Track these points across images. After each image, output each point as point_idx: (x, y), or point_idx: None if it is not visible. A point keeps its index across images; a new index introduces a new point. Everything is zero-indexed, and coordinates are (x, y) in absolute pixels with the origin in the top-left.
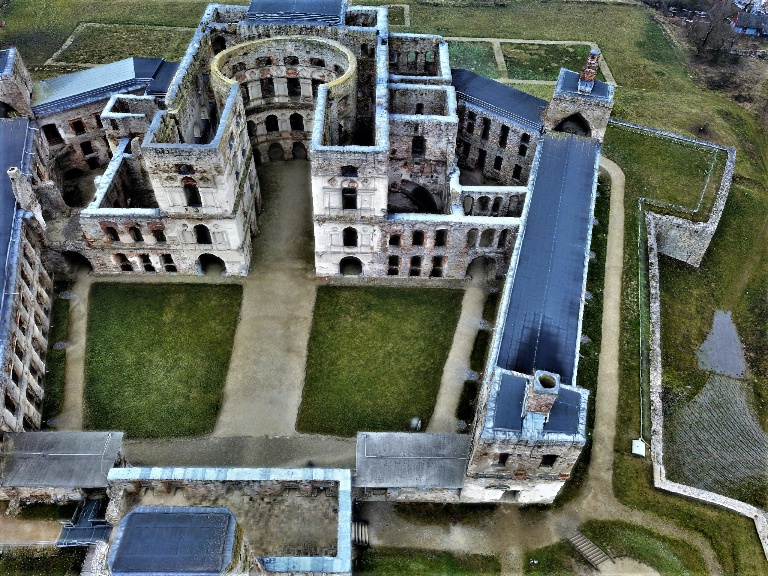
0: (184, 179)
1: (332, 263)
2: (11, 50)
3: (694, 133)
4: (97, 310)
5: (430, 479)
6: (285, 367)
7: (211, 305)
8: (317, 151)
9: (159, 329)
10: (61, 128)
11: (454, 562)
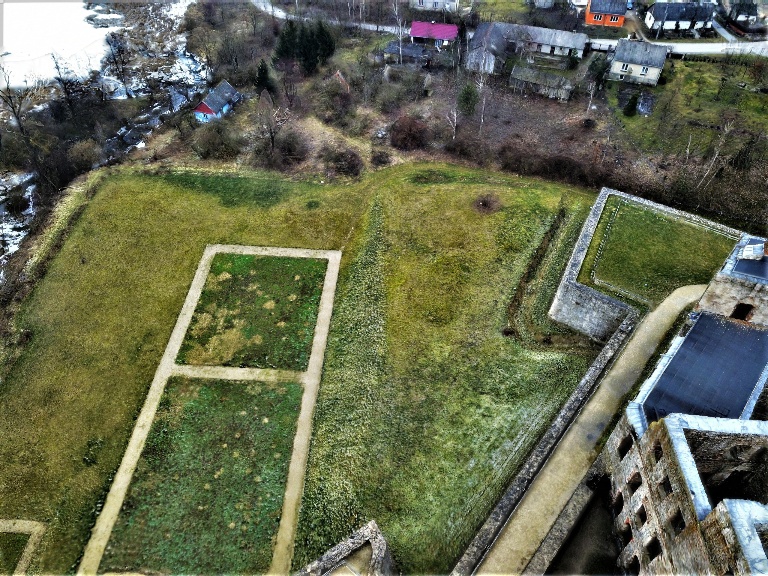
0: None
1: None
2: None
3: (492, 212)
4: None
5: None
6: None
7: None
8: None
9: None
10: None
11: None
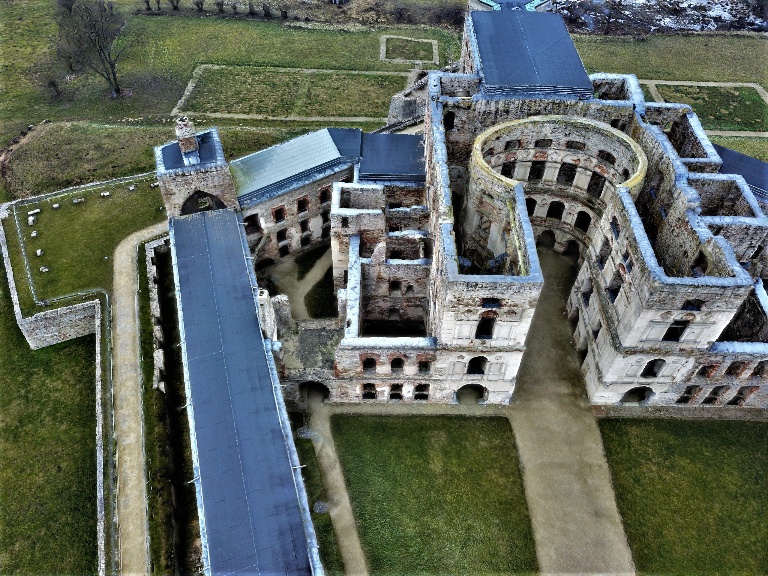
0: (484, 312)
1: (617, 392)
2: (214, 131)
3: None
4: (349, 455)
5: None
6: (602, 539)
7: (481, 447)
8: (665, 285)
9: (432, 483)
10: (263, 217)
11: None
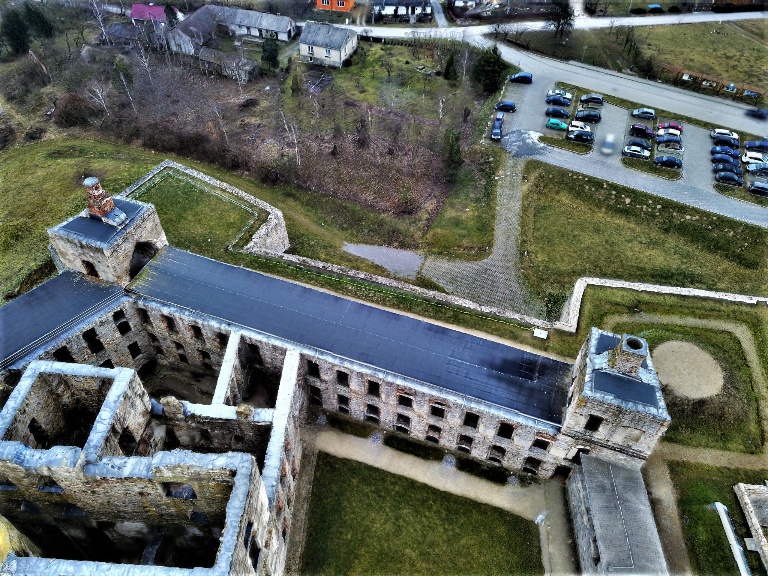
0: None
1: None
2: None
3: None
4: None
5: (641, 501)
6: None
7: None
8: (228, 575)
9: None
10: None
11: (686, 498)
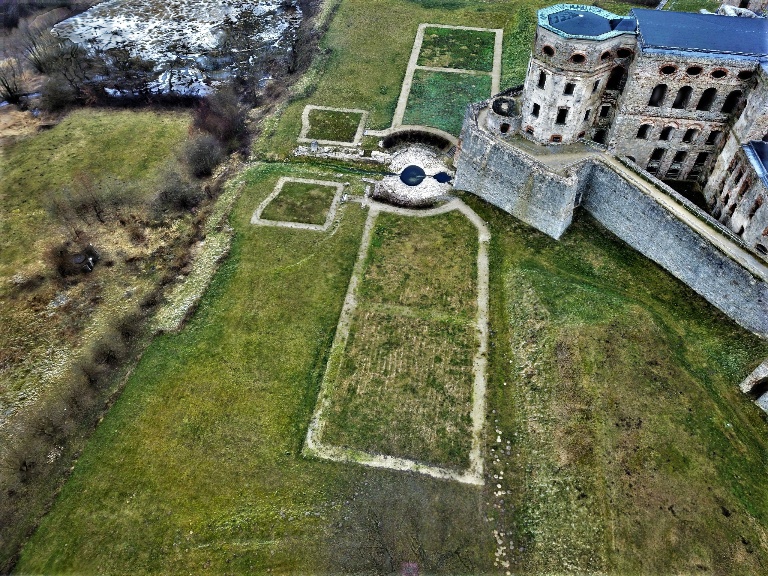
0: None
1: None
2: None
3: None
4: None
5: None
6: None
7: None
8: None
9: None
10: None
11: None
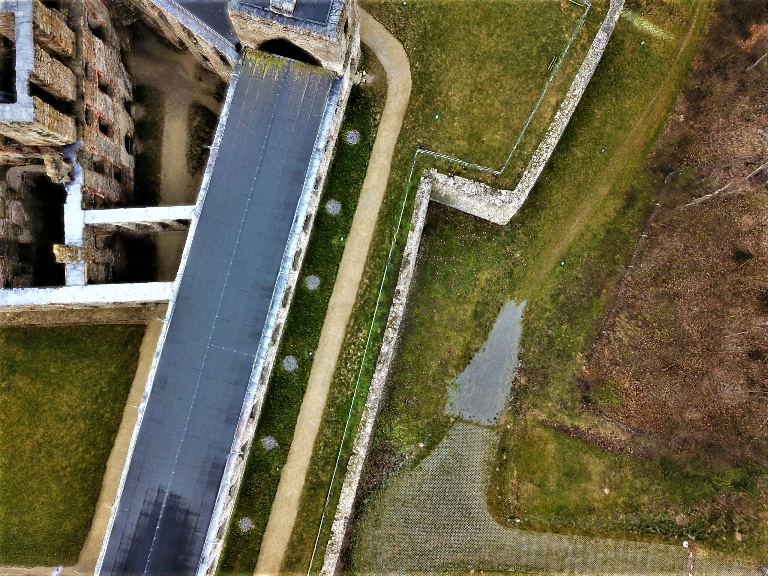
0: None
1: None
2: None
3: None
4: None
5: None
6: None
7: None
8: None
9: None
10: None
11: None
